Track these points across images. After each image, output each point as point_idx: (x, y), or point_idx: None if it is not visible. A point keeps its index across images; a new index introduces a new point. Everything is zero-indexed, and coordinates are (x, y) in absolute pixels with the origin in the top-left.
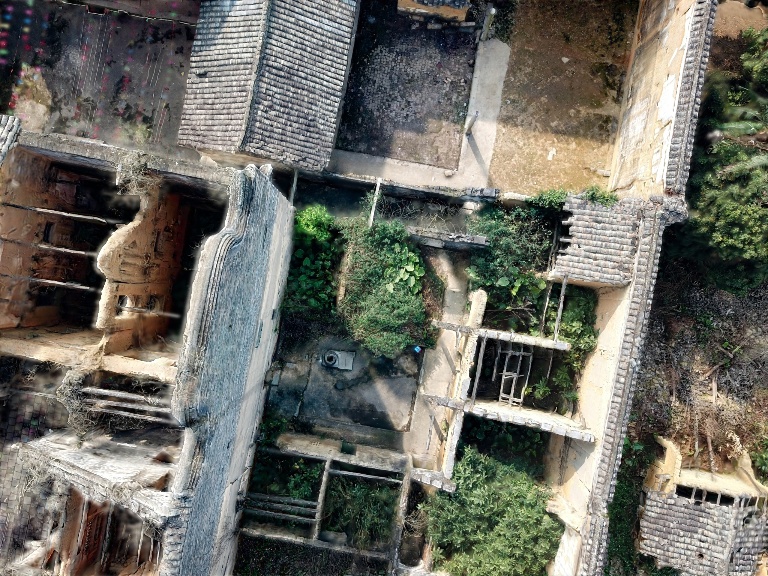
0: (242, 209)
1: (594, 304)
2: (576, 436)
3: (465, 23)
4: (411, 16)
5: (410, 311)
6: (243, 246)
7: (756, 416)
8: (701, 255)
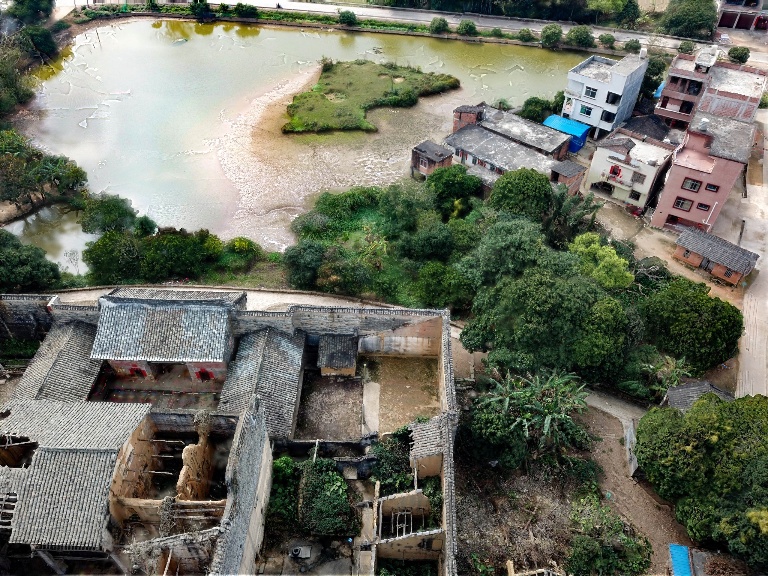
0: (255, 410)
1: (439, 481)
2: (435, 532)
3: (356, 377)
4: (329, 378)
5: (340, 504)
6: (254, 427)
7: (560, 547)
8: (491, 454)
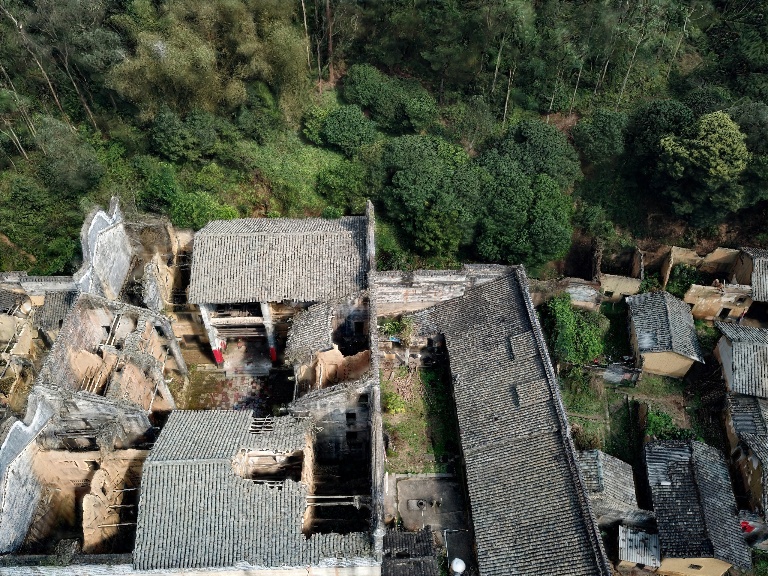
0: None
1: None
2: None
3: None
4: None
5: None
6: None
7: None
8: None
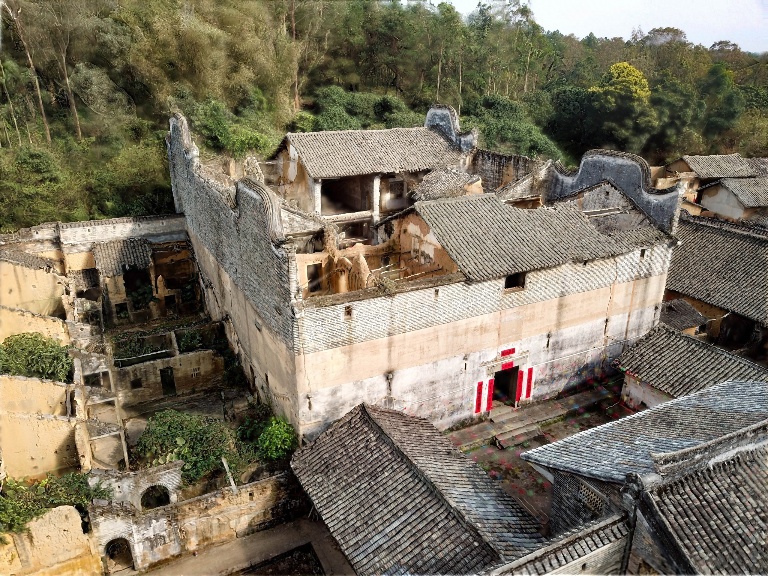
0: None
1: None
2: None
3: None
4: None
5: None
6: None
7: None
8: None
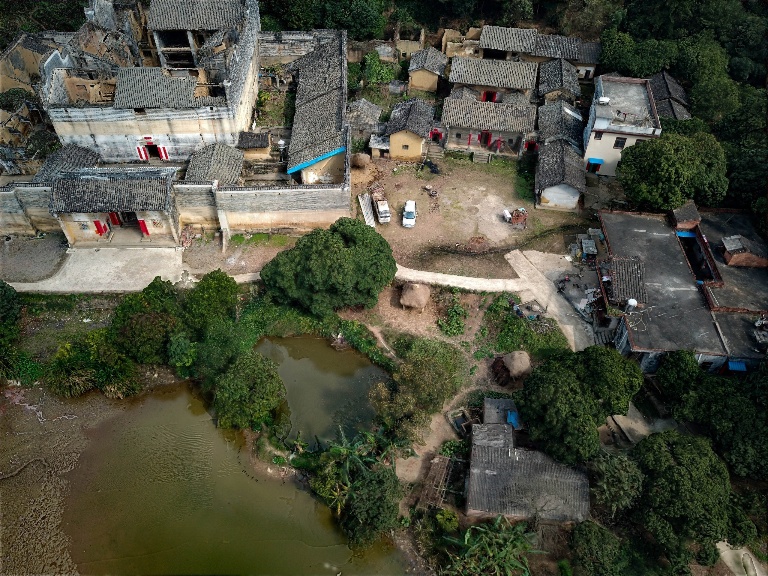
0: None
1: None
2: None
3: None
4: None
5: None
6: None
7: None
8: None
